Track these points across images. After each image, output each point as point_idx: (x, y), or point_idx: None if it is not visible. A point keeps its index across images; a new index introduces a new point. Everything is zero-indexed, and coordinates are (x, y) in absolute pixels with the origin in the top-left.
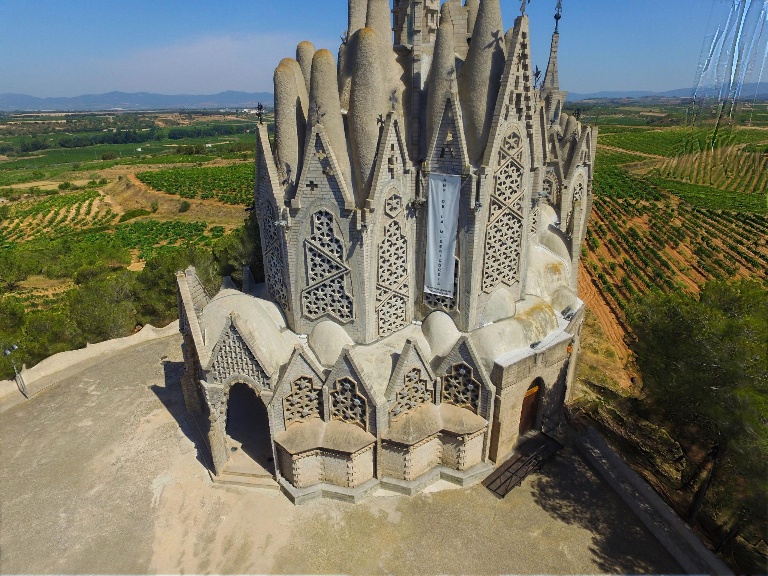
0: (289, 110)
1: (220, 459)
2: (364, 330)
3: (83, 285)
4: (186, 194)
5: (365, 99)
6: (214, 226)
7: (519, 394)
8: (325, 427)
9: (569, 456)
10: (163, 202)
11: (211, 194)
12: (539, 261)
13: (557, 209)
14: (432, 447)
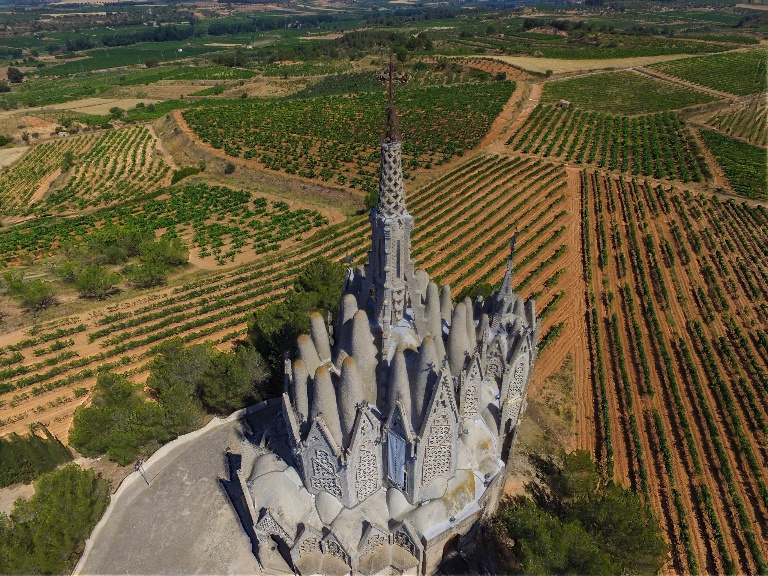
0: (302, 387)
1: (265, 561)
2: (348, 502)
3: (165, 355)
4: (231, 151)
5: (347, 396)
6: (257, 198)
7: (440, 546)
8: (323, 558)
9: (474, 572)
10: (210, 160)
11: (254, 153)
12: (474, 440)
13: (500, 384)
14: (386, 570)
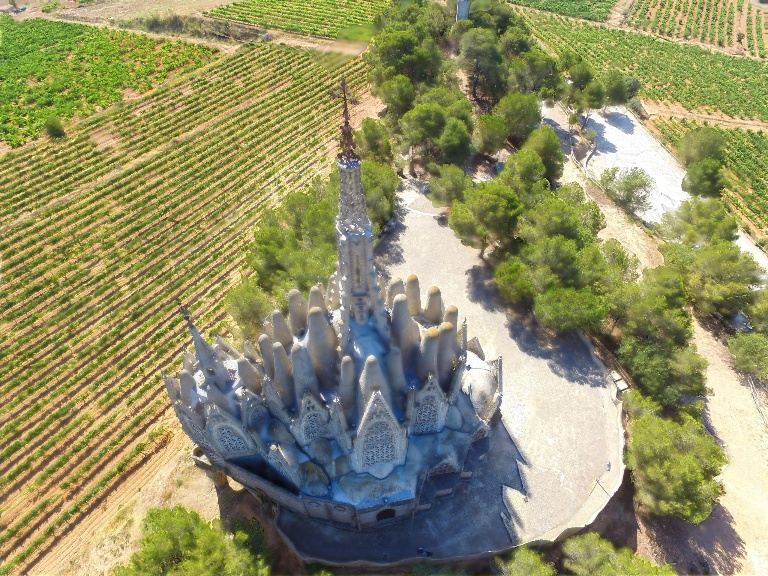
0: None
1: None
2: None
3: None
4: None
5: None
6: None
7: None
8: None
9: None
10: None
11: None
12: None
13: None
14: None
